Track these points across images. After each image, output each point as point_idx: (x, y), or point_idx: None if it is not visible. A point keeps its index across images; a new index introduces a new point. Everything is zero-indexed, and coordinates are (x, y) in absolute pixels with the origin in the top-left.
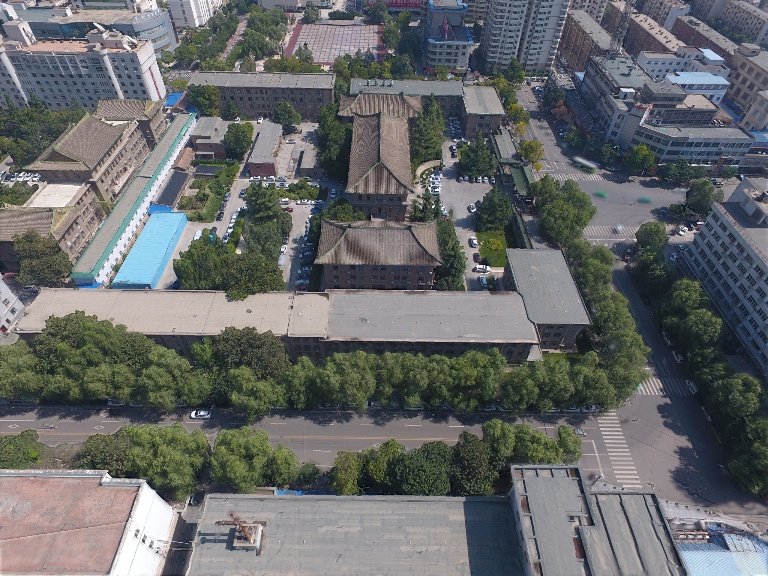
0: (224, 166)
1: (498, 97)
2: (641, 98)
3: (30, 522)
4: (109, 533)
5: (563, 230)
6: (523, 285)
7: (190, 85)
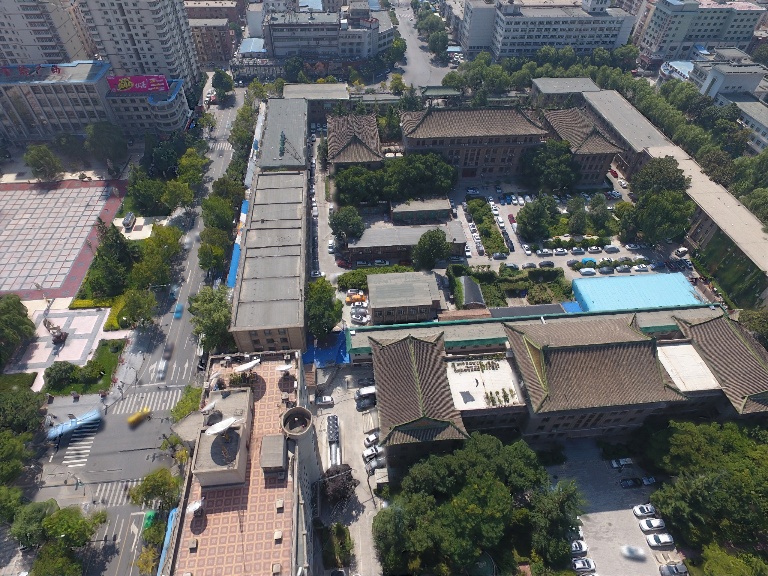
0: (460, 277)
1: (310, 84)
2: (353, 21)
3: None
4: None
5: None
6: (574, 91)
7: (314, 312)
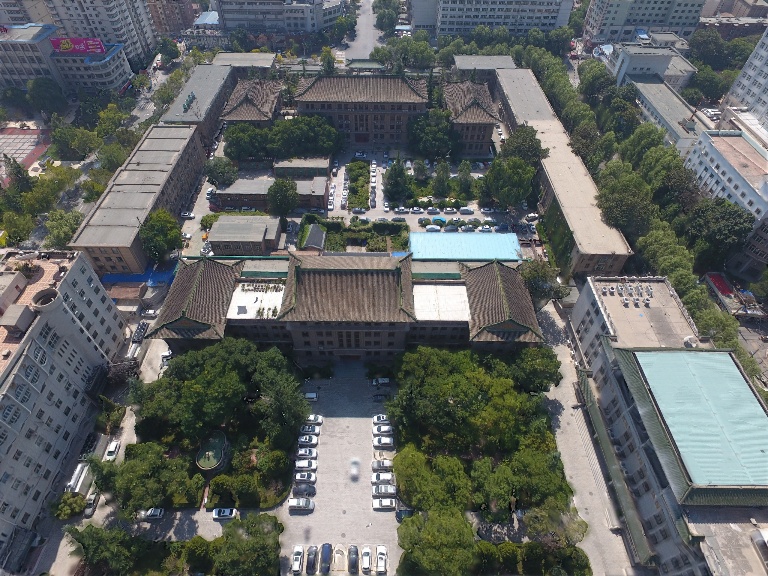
0: (310, 225)
1: (241, 53)
2: None
3: (745, 161)
4: (728, 140)
5: (432, 54)
6: (489, 68)
7: (142, 235)
